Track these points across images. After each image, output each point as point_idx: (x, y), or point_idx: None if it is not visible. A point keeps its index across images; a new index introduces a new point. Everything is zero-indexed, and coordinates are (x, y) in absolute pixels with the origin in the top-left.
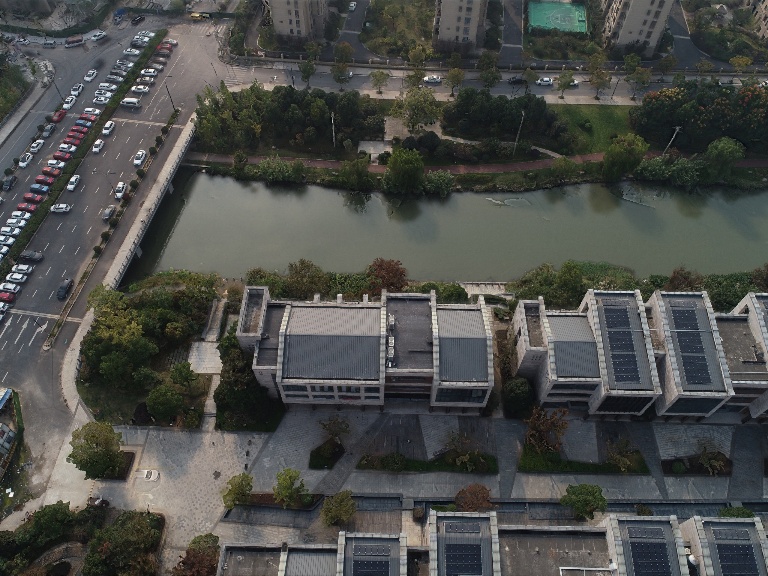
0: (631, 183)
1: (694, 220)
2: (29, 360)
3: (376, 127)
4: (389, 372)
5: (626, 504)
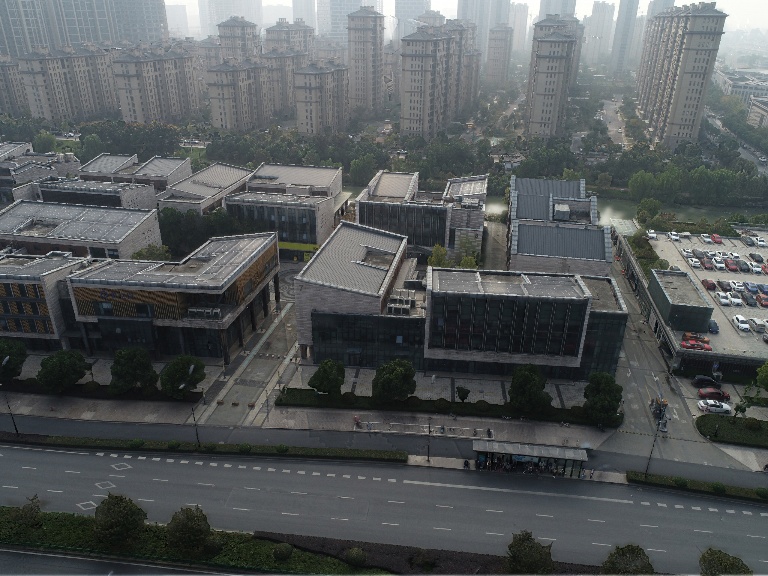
0: None
1: None
2: None
3: None
4: None
5: None
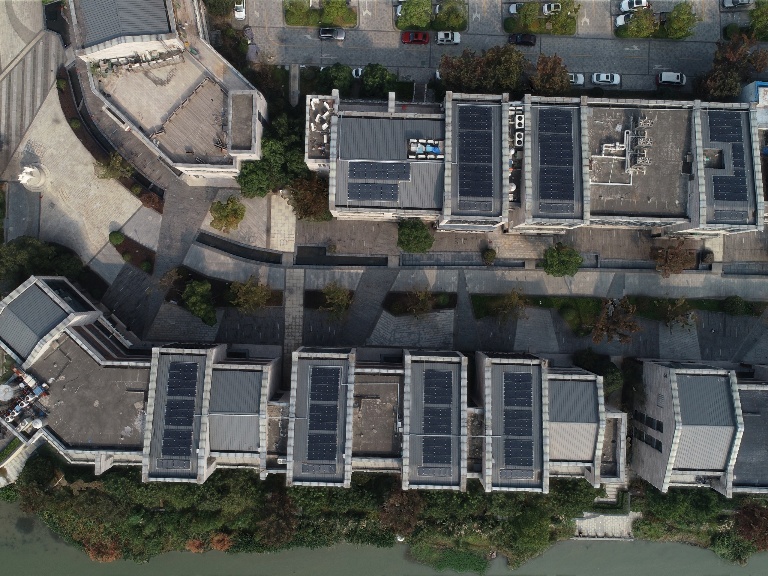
0: None
1: None
2: None
3: None
4: None
5: (502, 266)
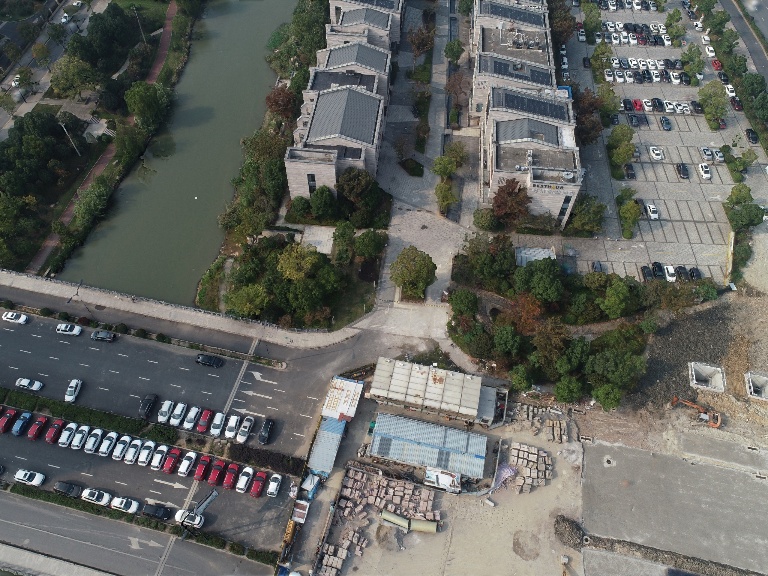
0: (202, 8)
1: None
2: (296, 379)
3: (76, 117)
4: None
5: None
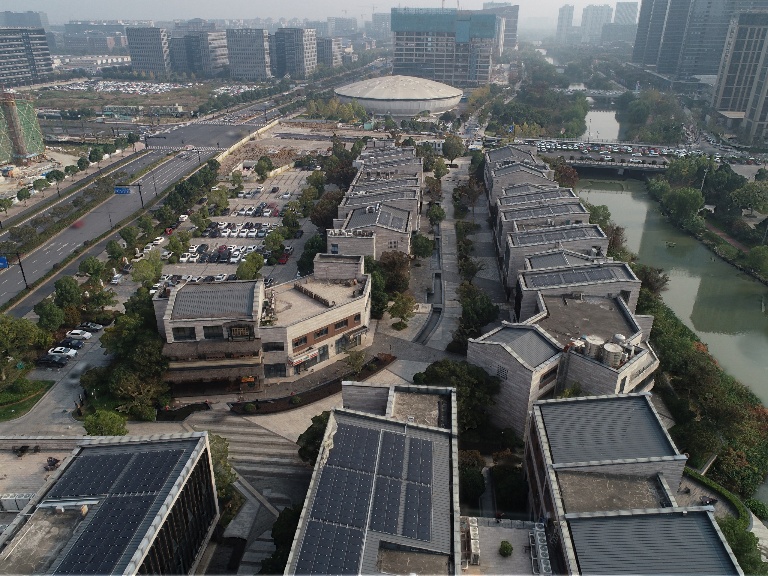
0: None
1: (763, 329)
2: None
3: (728, 199)
4: None
5: None
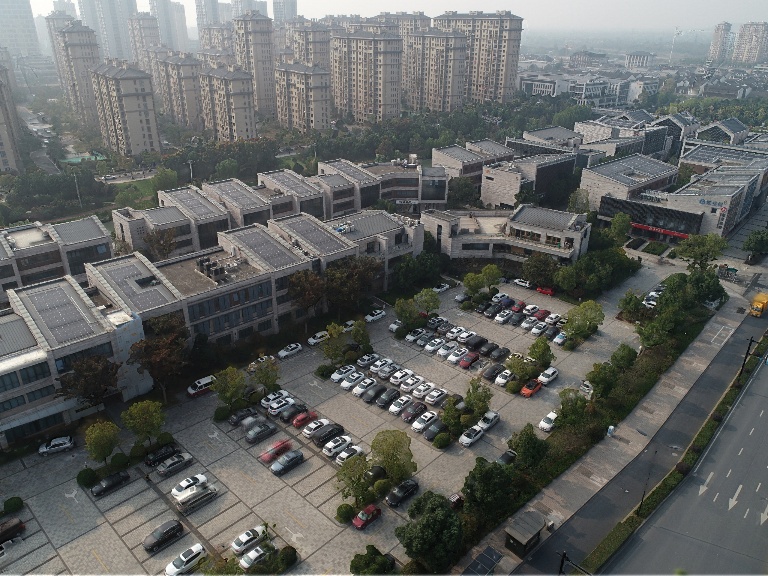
0: None
1: None
2: None
3: None
4: (16, 252)
5: None
